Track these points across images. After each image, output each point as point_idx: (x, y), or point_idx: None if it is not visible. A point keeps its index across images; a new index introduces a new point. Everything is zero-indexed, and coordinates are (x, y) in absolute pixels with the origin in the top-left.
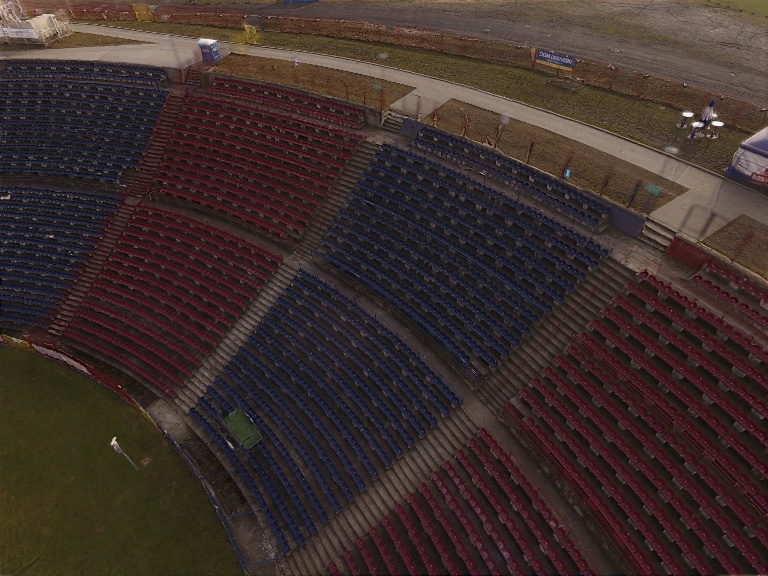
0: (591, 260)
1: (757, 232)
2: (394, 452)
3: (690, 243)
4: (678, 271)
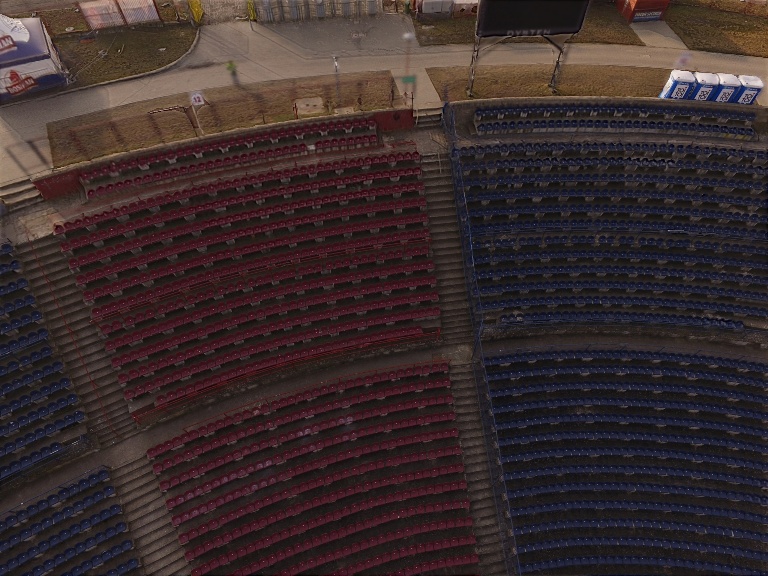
0: (8, 265)
1: (73, 127)
2: (131, 570)
3: (49, 176)
4: (74, 202)
